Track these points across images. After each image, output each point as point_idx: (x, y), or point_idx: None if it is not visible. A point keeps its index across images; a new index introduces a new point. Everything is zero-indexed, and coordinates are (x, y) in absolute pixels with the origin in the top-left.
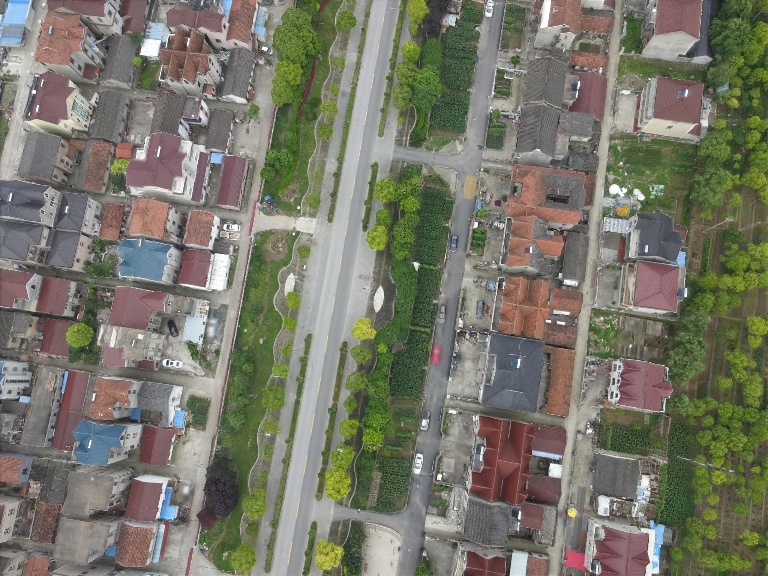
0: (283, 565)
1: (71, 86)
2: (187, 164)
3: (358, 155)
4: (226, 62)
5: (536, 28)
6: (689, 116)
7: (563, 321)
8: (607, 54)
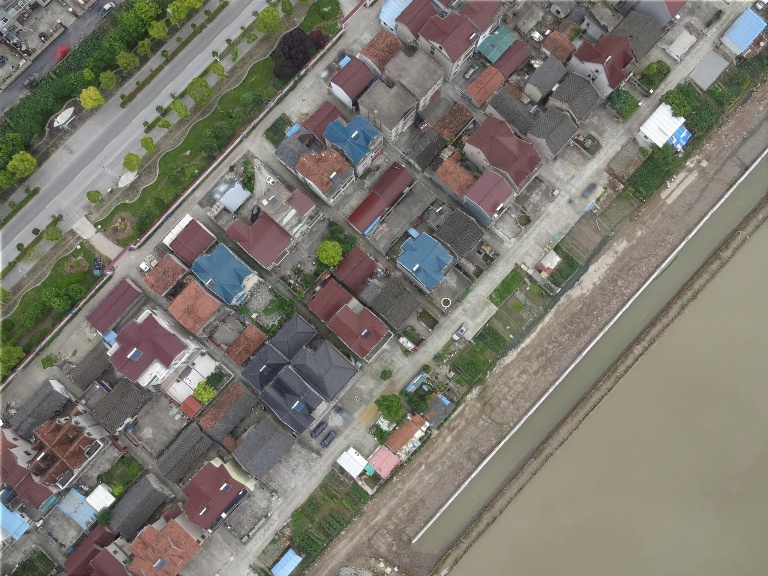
0: None
1: None
2: None
3: None
4: None
5: None
6: None
7: None
8: None
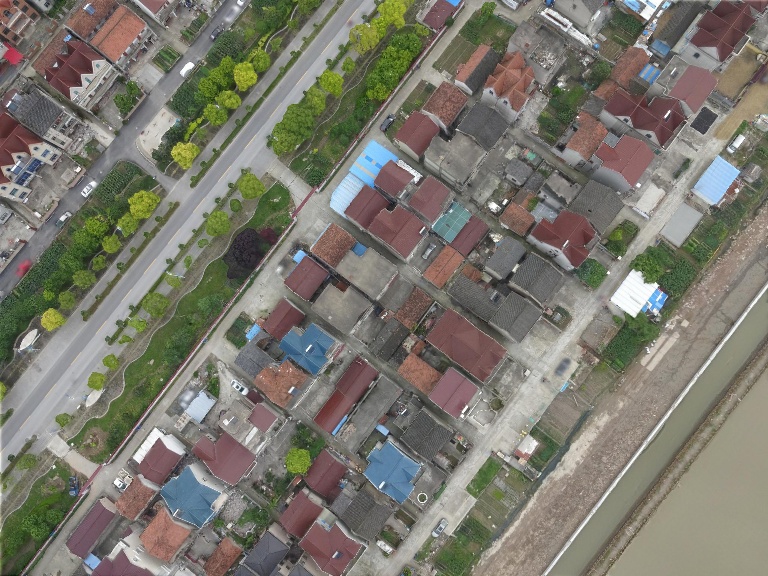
0: (235, 167)
1: None
2: None
3: None
4: None
5: None
6: None
7: None
8: None
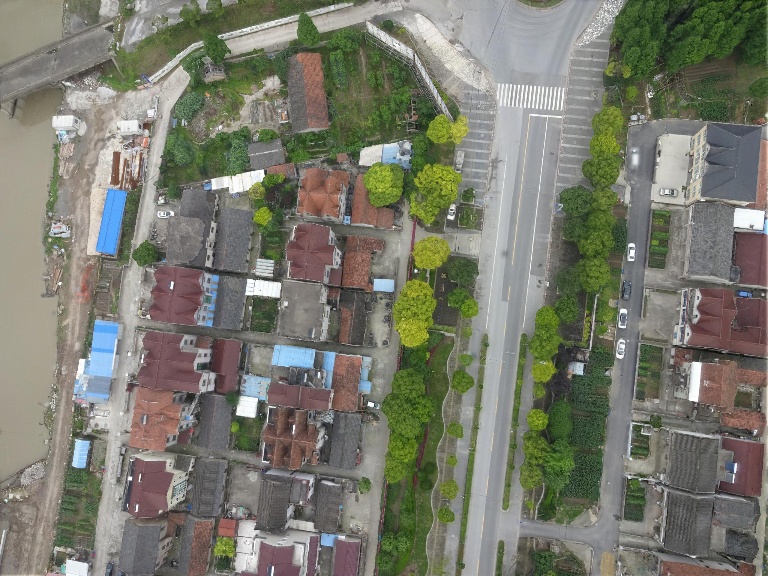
0: None
1: (167, 464)
2: (301, 570)
3: (481, 531)
4: (330, 423)
5: (678, 382)
6: None
7: None
8: (760, 406)
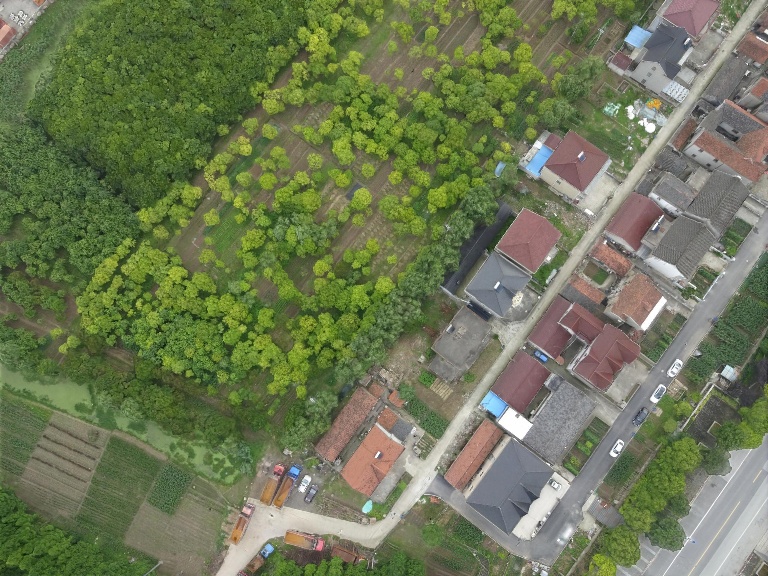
0: None
1: None
2: None
3: None
4: None
5: None
6: (579, 140)
7: (759, 37)
8: None
